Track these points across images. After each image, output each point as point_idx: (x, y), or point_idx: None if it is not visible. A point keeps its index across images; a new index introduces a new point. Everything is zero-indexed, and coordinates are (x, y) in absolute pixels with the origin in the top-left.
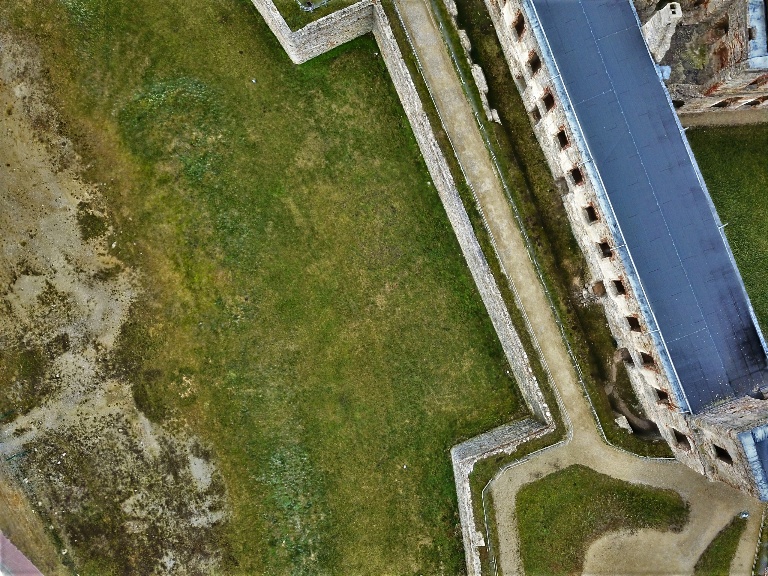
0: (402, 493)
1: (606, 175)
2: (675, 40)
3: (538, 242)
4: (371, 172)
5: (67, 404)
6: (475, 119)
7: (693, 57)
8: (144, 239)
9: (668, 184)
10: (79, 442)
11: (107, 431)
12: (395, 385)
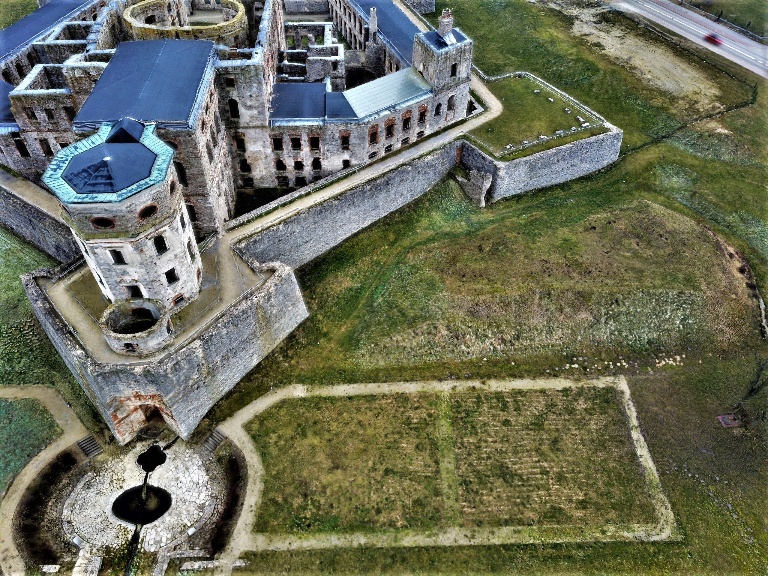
0: (453, 4)
1: None
2: None
3: None
4: None
5: (588, 12)
6: None
7: None
8: None
9: None
10: (580, 6)
11: (570, 7)
12: (459, 23)
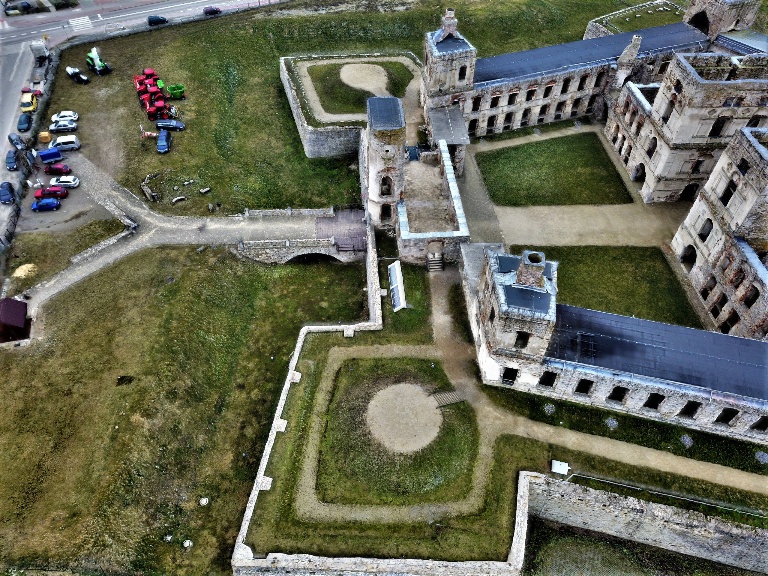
0: None
1: None
2: None
3: None
4: None
5: None
6: None
7: None
8: (493, 2)
9: None
10: None
11: None
12: None
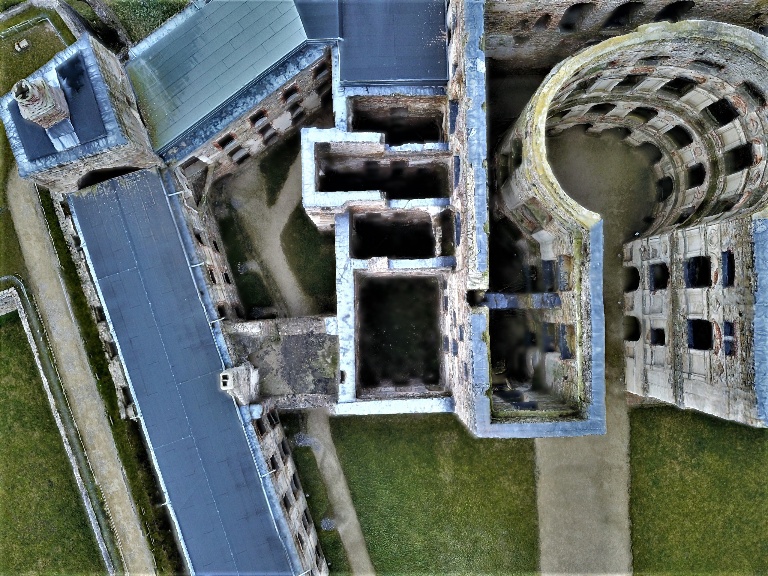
0: None
1: (183, 521)
2: (306, 349)
3: (163, 546)
4: (30, 444)
5: None
6: (107, 417)
7: (325, 365)
8: None
9: (244, 533)
10: None
11: None
12: None
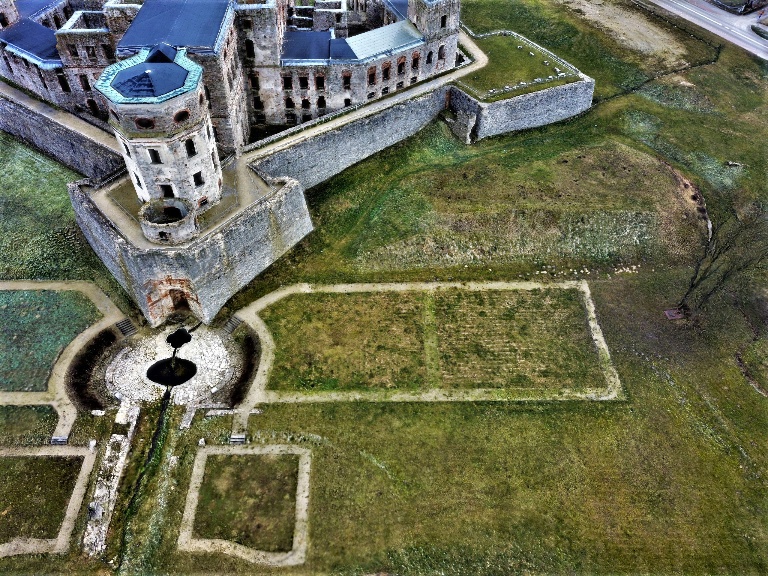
0: None
1: None
2: (352, 19)
3: None
4: None
5: None
6: None
7: None
8: (556, 8)
9: None
10: None
11: None
12: None
